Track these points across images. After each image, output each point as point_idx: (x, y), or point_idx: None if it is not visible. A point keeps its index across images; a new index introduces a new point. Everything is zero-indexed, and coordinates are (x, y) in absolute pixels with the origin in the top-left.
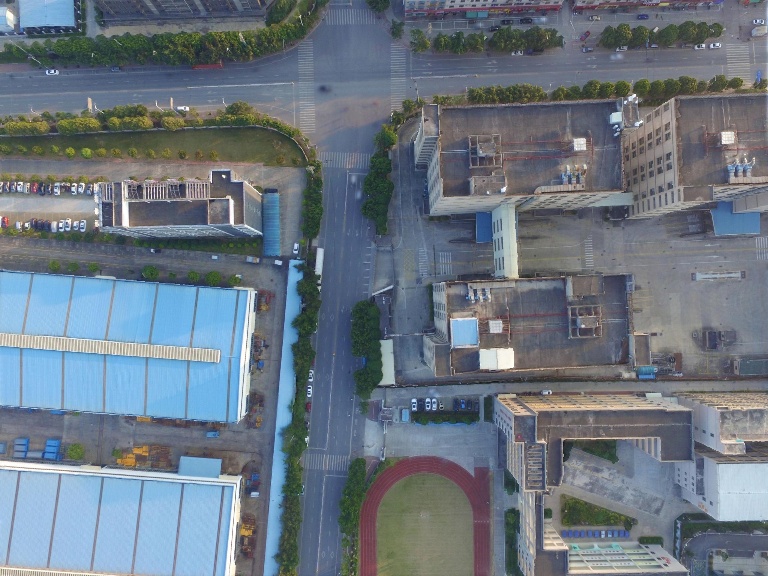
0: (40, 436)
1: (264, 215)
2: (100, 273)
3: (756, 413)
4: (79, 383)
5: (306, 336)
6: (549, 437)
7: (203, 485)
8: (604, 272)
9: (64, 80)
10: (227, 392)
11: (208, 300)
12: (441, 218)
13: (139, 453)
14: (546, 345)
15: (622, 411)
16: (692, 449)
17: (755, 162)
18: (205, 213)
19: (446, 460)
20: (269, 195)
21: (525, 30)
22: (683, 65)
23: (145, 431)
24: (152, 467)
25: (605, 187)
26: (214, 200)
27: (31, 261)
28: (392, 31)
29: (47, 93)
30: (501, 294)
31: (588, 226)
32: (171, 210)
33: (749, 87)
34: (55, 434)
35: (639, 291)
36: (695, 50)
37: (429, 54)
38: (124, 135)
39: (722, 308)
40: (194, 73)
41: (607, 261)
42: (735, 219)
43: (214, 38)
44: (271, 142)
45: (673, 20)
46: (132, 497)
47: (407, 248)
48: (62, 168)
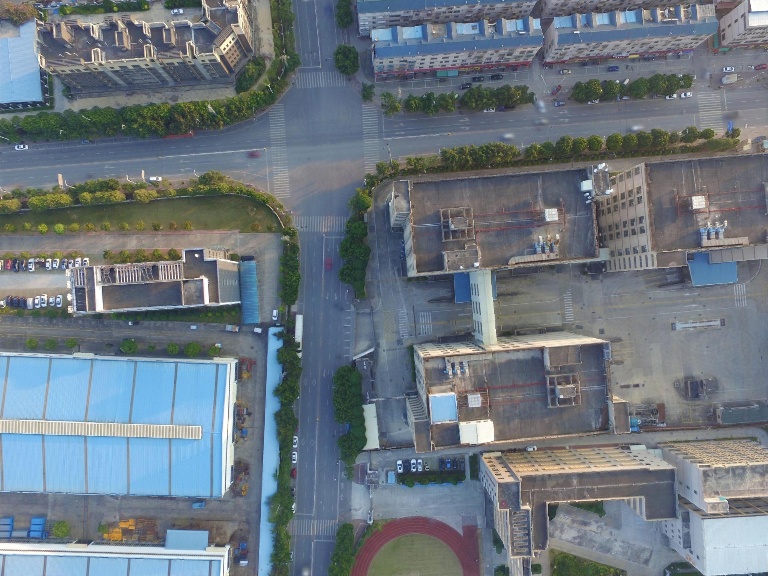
0: (25, 514)
1: (241, 283)
2: (78, 348)
3: (738, 469)
4: (60, 465)
5: (288, 404)
6: (534, 501)
7: (190, 560)
8: (584, 325)
9: (34, 154)
10: (210, 467)
11: (187, 376)
12: (419, 278)
13: (125, 527)
14: (526, 415)
15: (605, 472)
16: (676, 507)
17: (727, 223)
18: (179, 293)
19: (434, 520)
20: (245, 263)
21: (496, 86)
22: (655, 115)
23: (130, 504)
24: (139, 541)
25: (579, 254)
26: (188, 281)
27: (8, 339)
28: (362, 94)
29: (17, 168)
30: (479, 366)
31: (567, 280)
32: (145, 291)
33: (721, 135)
34: (40, 512)
35: (620, 343)
36: (667, 100)
37: (401, 114)
38: (97, 208)
39: (703, 357)
40: (165, 142)
41: (587, 314)
42: (712, 269)
43: (183, 110)
44: (246, 209)
45: (644, 70)
46: (119, 575)
47: (386, 310)
48: (36, 243)
